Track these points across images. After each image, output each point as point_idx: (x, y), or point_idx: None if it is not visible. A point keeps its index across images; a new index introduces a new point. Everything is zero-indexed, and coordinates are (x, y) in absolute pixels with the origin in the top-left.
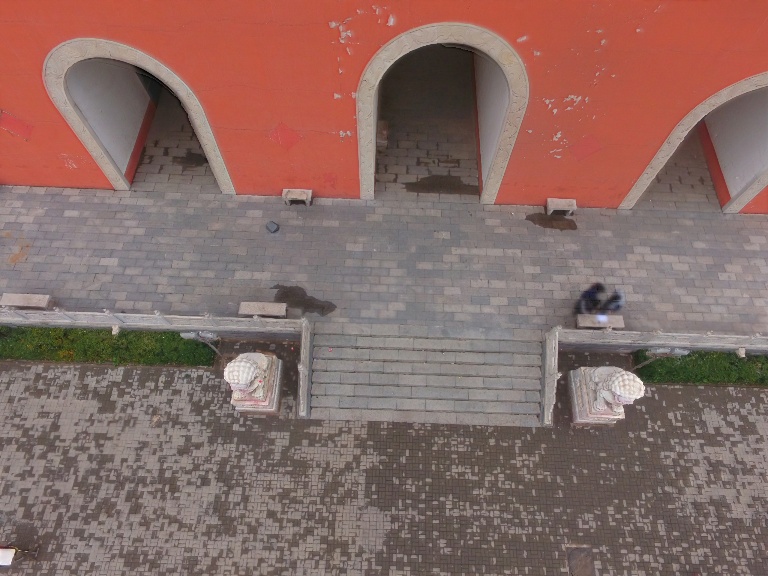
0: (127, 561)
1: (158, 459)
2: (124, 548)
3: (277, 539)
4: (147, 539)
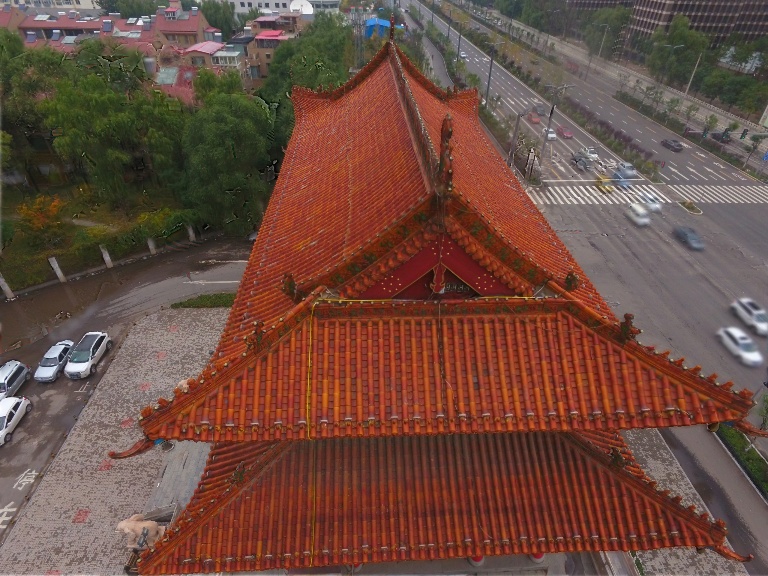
0: (734, 571)
1: (688, 568)
2: (731, 575)
3: (682, 502)
4: (720, 564)
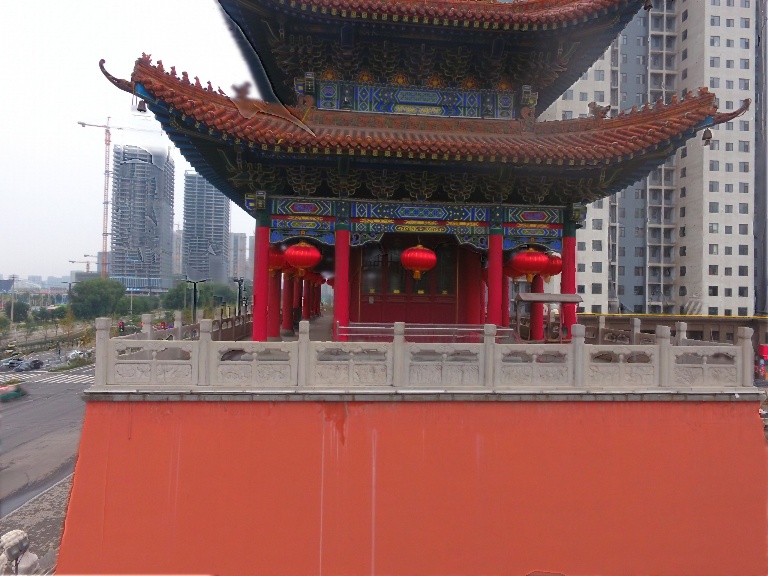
0: None
1: None
2: None
3: None
4: None
